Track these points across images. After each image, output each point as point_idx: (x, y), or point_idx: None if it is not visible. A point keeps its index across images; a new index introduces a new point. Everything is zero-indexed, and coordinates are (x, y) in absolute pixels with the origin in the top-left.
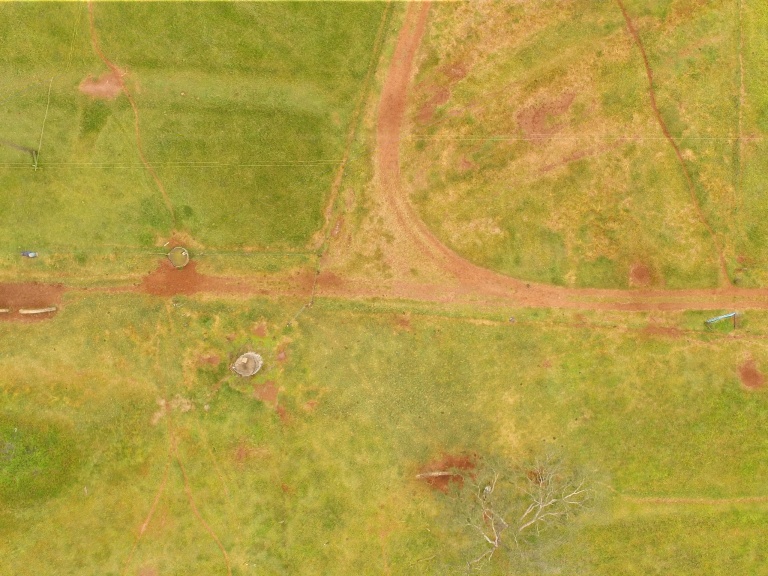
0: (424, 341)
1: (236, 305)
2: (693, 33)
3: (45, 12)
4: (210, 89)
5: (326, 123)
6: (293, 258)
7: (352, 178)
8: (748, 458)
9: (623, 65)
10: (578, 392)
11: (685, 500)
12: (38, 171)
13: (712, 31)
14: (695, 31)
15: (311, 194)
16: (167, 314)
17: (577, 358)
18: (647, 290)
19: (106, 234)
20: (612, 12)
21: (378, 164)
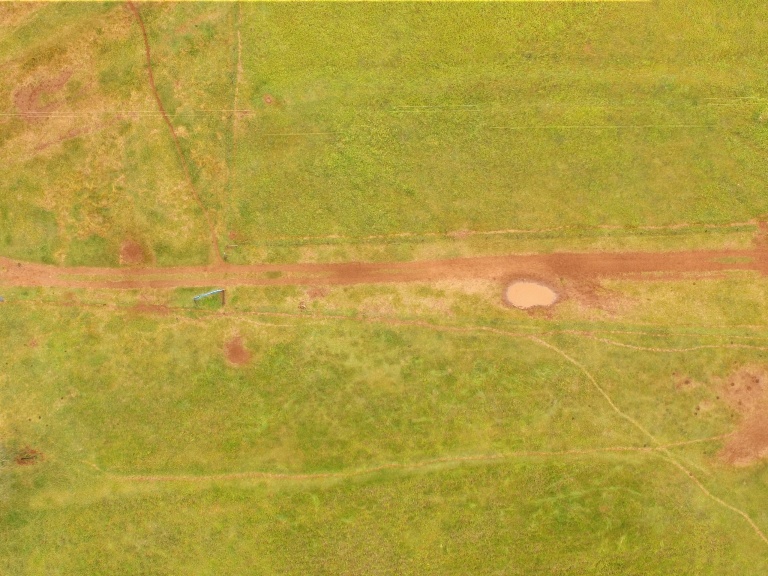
0: None
1: None
2: (193, 10)
3: None
4: None
5: None
6: None
7: None
8: (231, 434)
9: (123, 43)
10: (64, 371)
11: (169, 478)
12: None
13: (210, 8)
14: (194, 8)
15: None
16: None
17: (63, 337)
18: (139, 268)
19: None
20: None
21: None
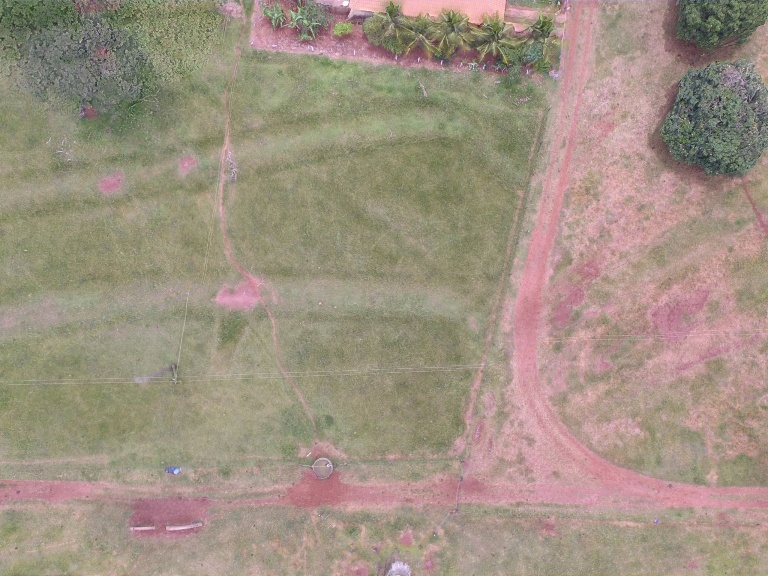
0: (570, 546)
1: (381, 514)
2: None
3: (178, 223)
4: (347, 297)
5: (464, 328)
6: (436, 465)
7: (491, 382)
8: None
9: (755, 260)
10: None
11: None
12: (178, 384)
13: None
14: None
15: (451, 399)
16: (312, 525)
17: (722, 558)
18: None
19: (248, 446)
20: (742, 207)
21: (517, 368)
